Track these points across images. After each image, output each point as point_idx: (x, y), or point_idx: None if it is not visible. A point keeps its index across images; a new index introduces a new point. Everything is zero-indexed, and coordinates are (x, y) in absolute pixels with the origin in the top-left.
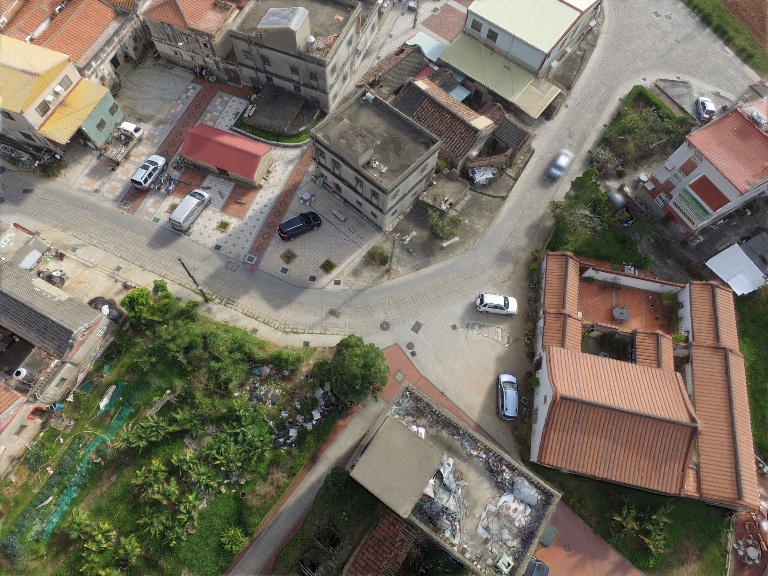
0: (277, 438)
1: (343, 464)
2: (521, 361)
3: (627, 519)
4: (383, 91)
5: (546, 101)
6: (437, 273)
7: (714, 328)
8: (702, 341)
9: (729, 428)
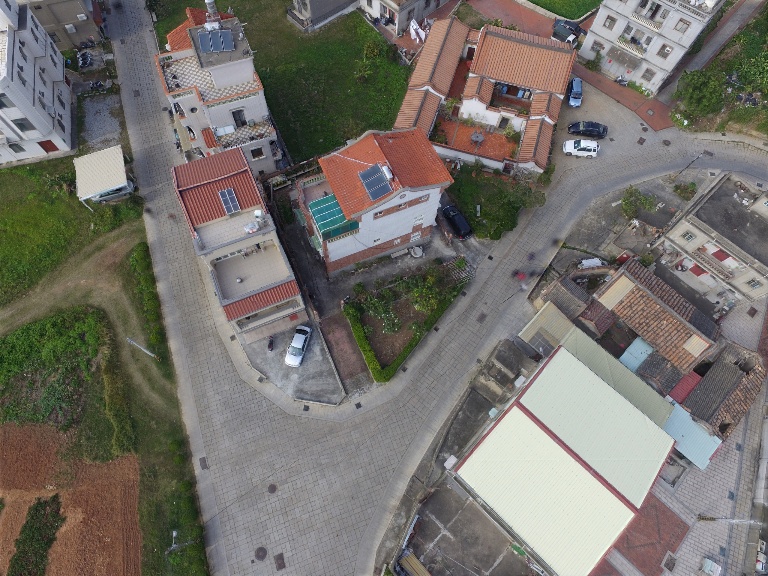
0: (731, 77)
1: (680, 72)
2: (560, 116)
3: (512, 29)
4: (732, 357)
5: (537, 322)
6: (629, 178)
7: (425, 102)
8: (436, 98)
9: (445, 46)
